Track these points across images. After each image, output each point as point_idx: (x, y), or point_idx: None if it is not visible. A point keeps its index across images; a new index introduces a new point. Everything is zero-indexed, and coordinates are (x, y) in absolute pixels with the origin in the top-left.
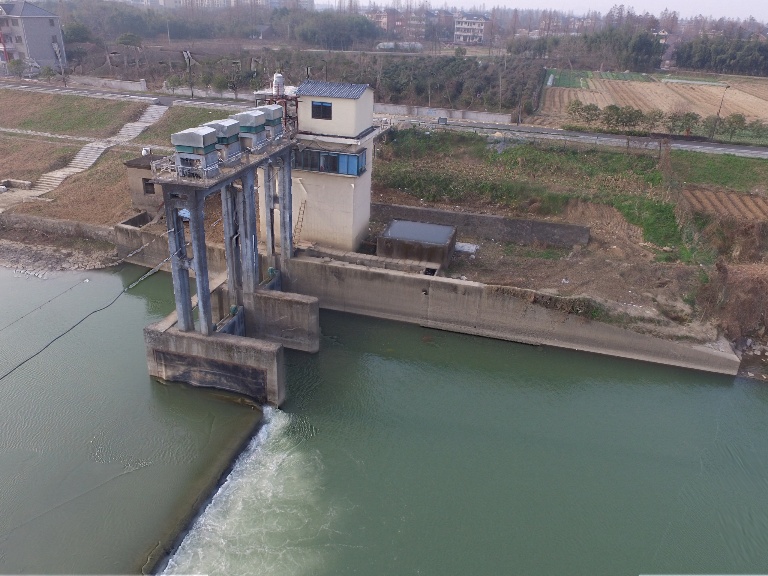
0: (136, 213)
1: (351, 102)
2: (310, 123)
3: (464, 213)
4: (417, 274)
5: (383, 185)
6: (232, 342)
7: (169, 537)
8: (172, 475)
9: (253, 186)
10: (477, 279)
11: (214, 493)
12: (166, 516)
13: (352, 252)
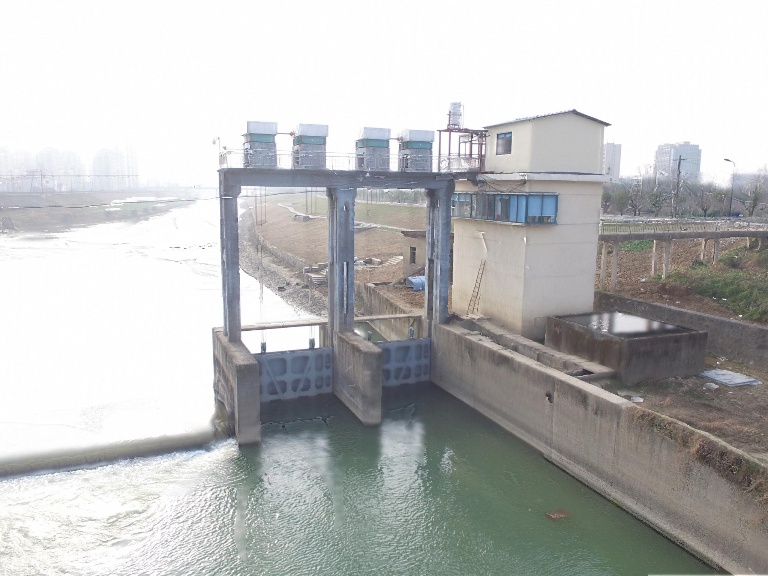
0: None
1: (528, 126)
2: (494, 161)
3: (759, 326)
4: (551, 368)
5: (686, 289)
6: (231, 350)
7: None
8: (84, 443)
9: (352, 204)
10: (659, 407)
11: (69, 469)
12: (17, 460)
13: (519, 335)
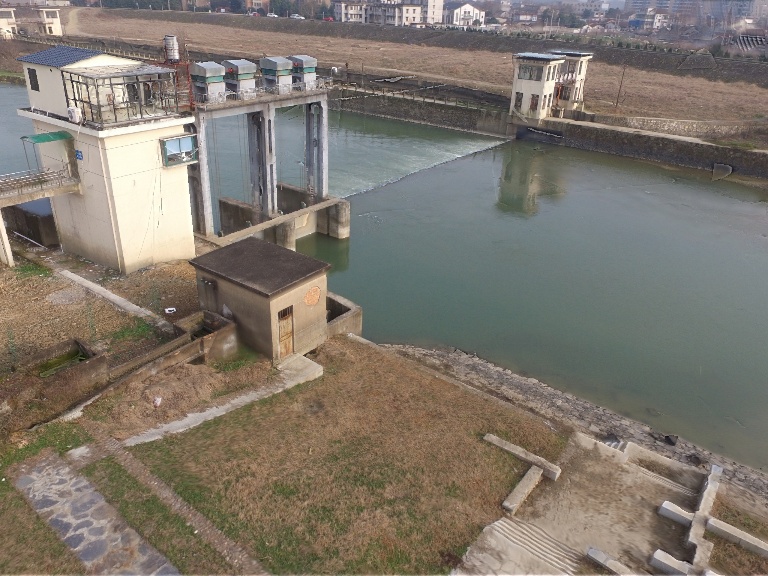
0: (324, 344)
1: None
2: None
3: None
4: None
5: None
6: None
7: (354, 194)
8: None
9: None
10: None
11: None
12: (354, 200)
13: None
